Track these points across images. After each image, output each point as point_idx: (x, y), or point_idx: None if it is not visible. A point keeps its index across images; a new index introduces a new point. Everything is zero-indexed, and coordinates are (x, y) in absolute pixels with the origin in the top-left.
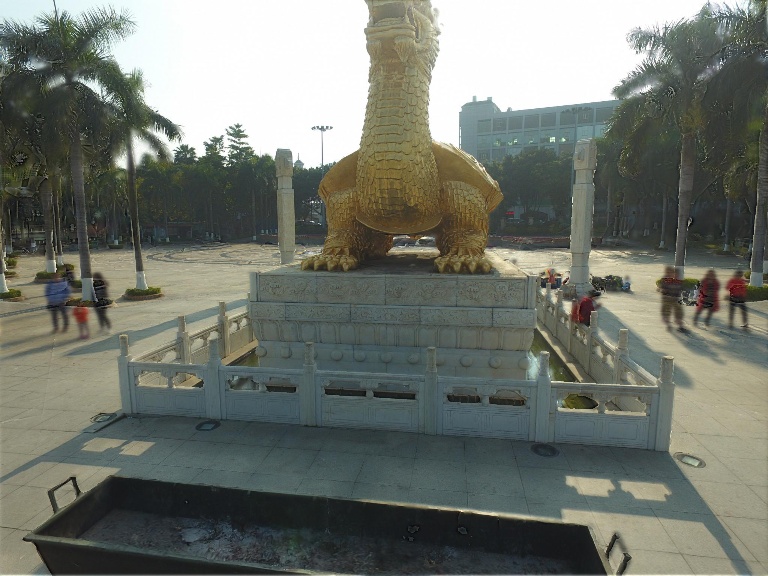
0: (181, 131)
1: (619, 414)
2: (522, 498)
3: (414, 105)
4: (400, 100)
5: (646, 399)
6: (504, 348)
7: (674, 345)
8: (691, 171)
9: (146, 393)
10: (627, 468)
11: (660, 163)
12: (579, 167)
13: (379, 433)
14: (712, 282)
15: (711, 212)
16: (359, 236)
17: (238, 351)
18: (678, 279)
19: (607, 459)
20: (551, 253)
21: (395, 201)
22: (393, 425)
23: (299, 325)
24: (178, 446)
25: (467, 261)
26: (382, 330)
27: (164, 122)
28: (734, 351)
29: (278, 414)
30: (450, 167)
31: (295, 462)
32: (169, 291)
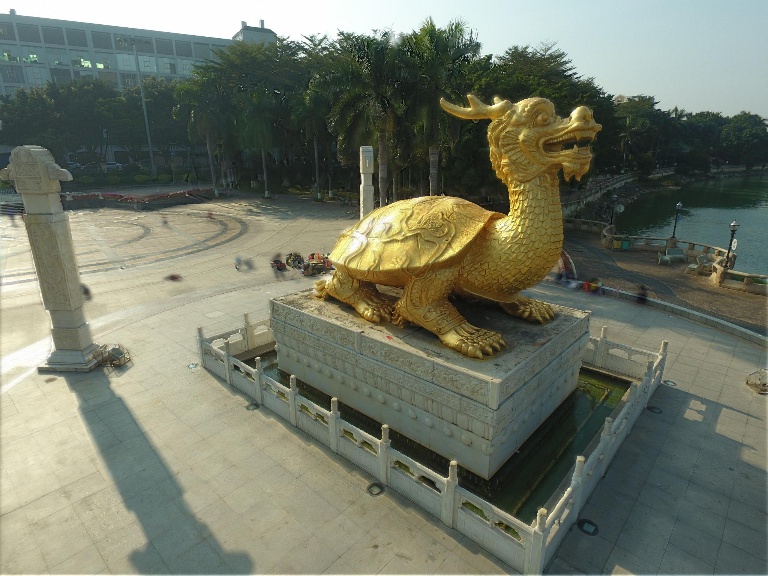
0: None
1: None
2: (706, 437)
3: None
4: None
5: None
6: None
7: None
8: (386, 163)
9: (549, 547)
10: None
11: None
12: (366, 171)
13: (623, 451)
14: None
15: (306, 167)
16: None
17: None
18: None
19: None
20: (187, 213)
21: None
22: None
23: None
24: (627, 552)
25: (547, 309)
26: None
27: None
28: None
29: None
30: None
31: (662, 497)
32: None
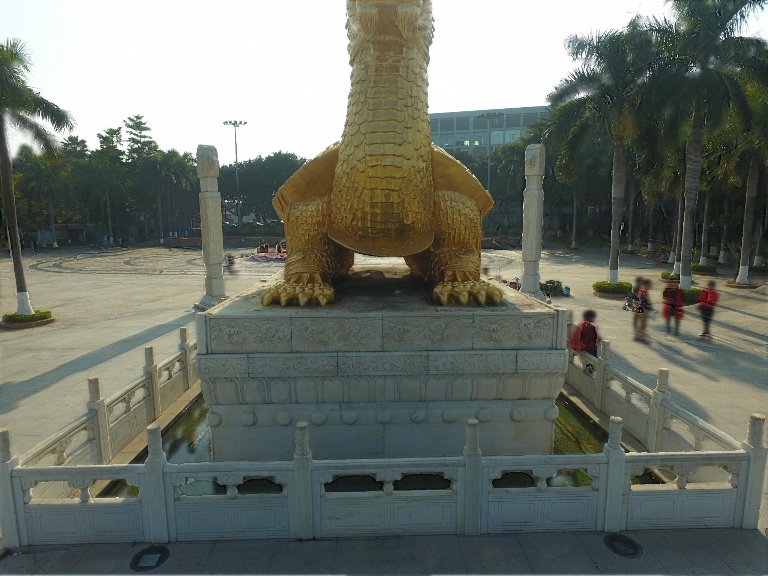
0: (74, 120)
1: (702, 488)
2: None
3: (415, 96)
4: (398, 89)
5: (734, 468)
6: (528, 397)
7: (657, 363)
8: (623, 178)
9: (44, 514)
10: (733, 566)
11: (594, 170)
12: (530, 173)
13: (404, 541)
14: (636, 283)
15: None
16: (329, 257)
17: (171, 407)
18: (613, 283)
19: (701, 552)
20: None
21: (389, 218)
22: (421, 527)
23: (267, 382)
24: None
25: (474, 290)
26: (379, 383)
27: (50, 108)
28: (716, 367)
29: (256, 527)
30: (444, 174)
31: None
32: (62, 314)
